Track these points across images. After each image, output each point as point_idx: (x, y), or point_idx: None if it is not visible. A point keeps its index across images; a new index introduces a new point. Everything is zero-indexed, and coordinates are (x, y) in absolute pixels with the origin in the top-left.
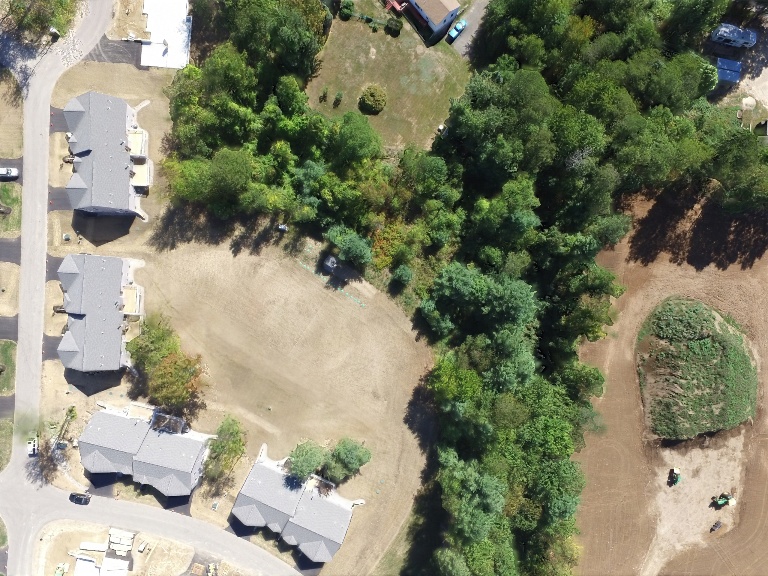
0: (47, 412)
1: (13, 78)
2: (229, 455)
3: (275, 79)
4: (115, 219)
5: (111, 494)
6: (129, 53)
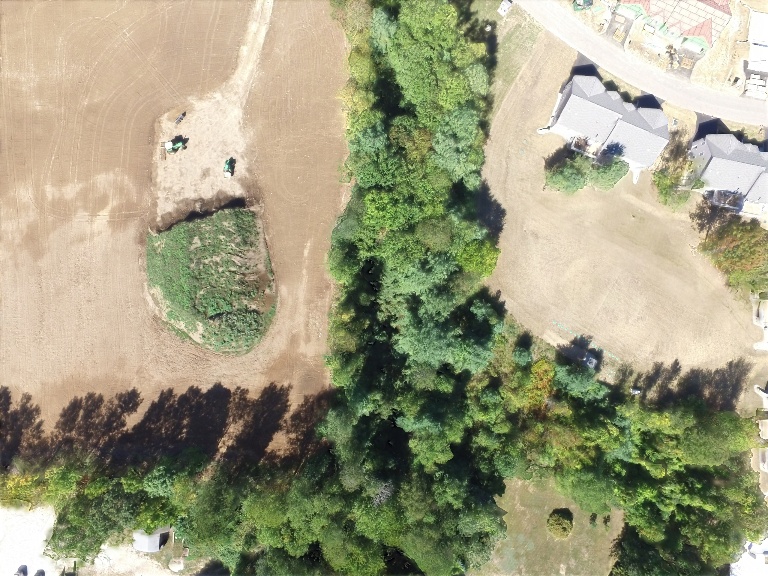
0: None
1: None
2: None
3: None
4: None
5: (767, 130)
6: None
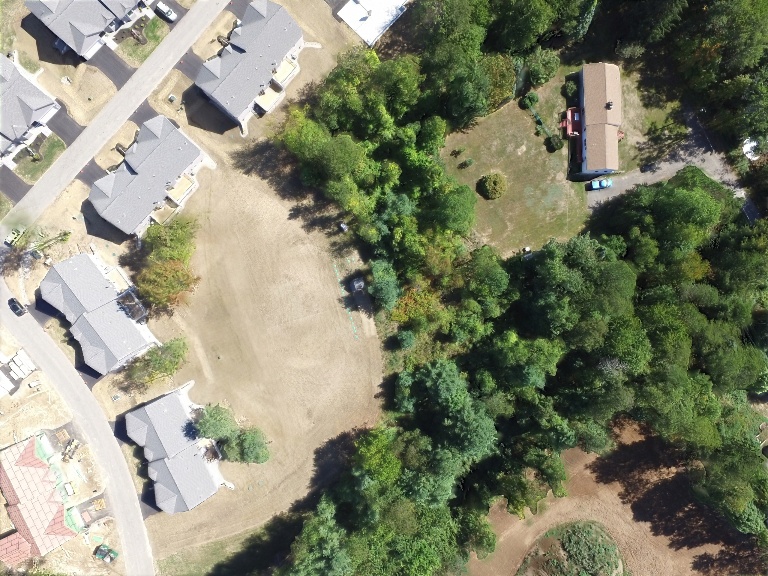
0: (46, 220)
1: None
2: (159, 367)
3: (431, 110)
4: (220, 115)
5: (44, 323)
6: None
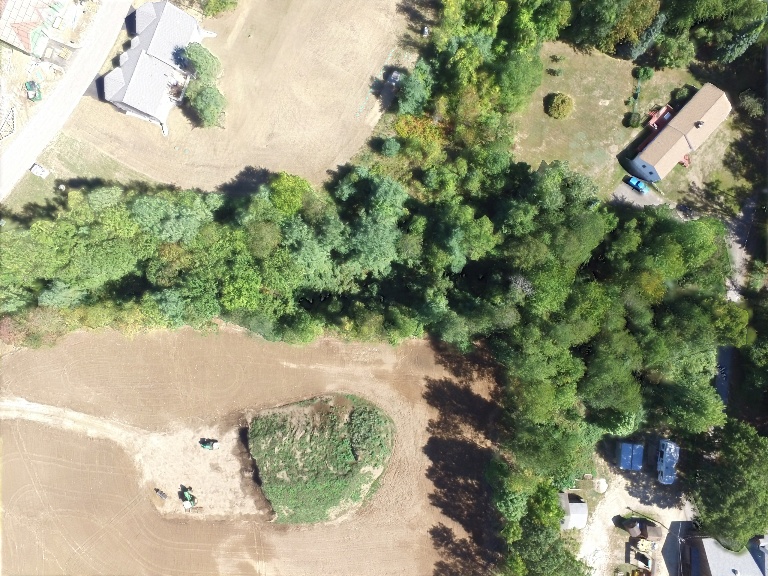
0: None
1: None
2: None
3: None
4: None
5: None
6: None
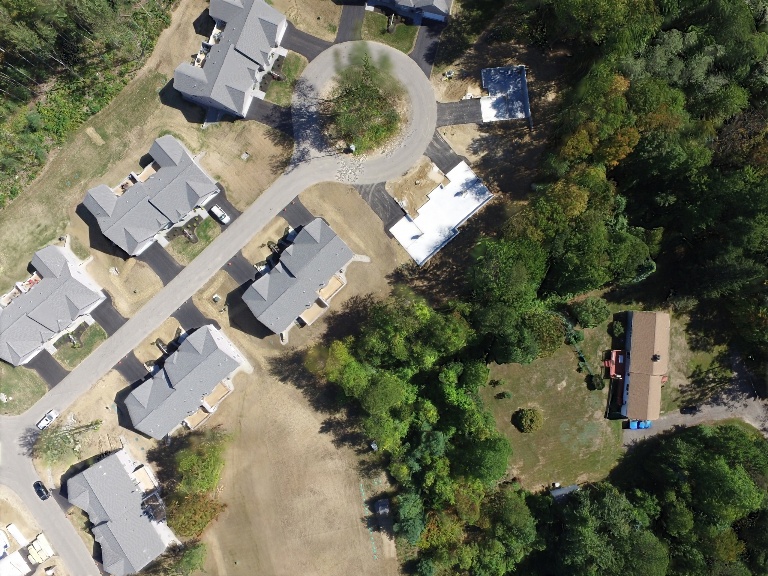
0: (80, 406)
1: (291, 151)
2: (175, 566)
3: None
4: None
5: (66, 509)
6: (389, 213)
